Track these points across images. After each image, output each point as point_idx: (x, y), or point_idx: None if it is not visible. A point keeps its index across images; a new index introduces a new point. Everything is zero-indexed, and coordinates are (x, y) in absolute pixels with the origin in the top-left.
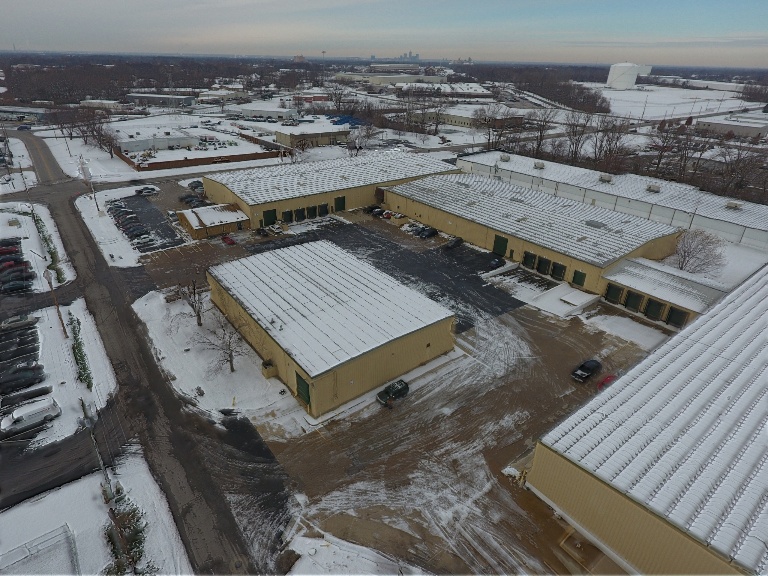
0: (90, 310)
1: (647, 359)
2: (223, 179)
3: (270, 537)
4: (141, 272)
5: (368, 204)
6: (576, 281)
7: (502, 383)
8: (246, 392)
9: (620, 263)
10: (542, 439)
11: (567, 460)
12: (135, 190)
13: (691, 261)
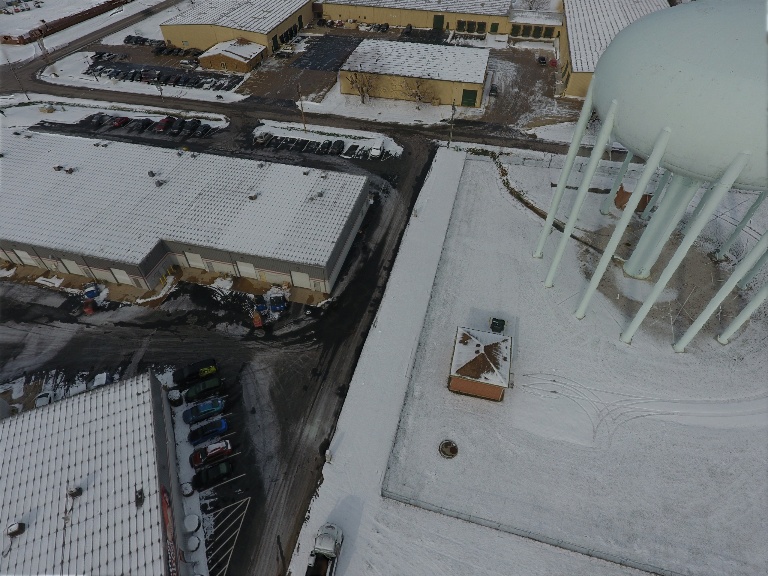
0: (284, 121)
1: (570, 42)
2: (197, 21)
3: (520, 135)
4: (261, 98)
5: (310, 20)
6: (492, 30)
7: (520, 76)
8: (439, 113)
9: (511, 12)
10: (573, 71)
11: (586, 72)
12: (90, 57)
13: (534, 4)
